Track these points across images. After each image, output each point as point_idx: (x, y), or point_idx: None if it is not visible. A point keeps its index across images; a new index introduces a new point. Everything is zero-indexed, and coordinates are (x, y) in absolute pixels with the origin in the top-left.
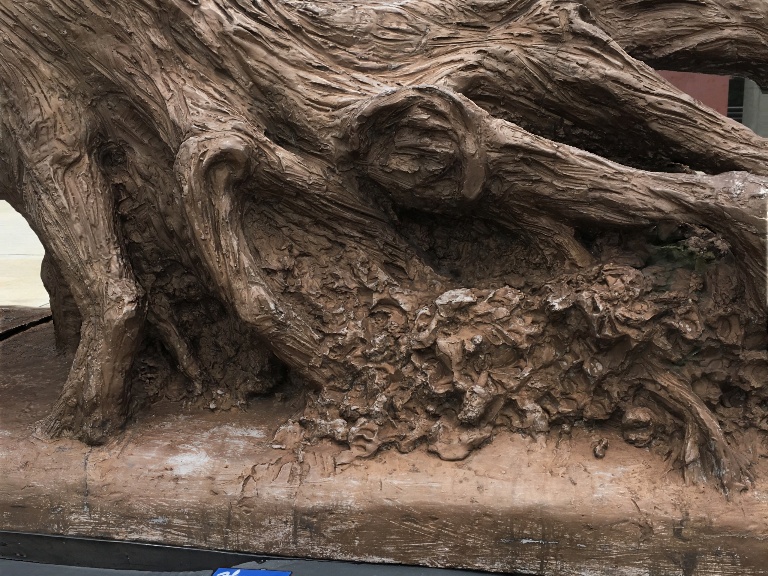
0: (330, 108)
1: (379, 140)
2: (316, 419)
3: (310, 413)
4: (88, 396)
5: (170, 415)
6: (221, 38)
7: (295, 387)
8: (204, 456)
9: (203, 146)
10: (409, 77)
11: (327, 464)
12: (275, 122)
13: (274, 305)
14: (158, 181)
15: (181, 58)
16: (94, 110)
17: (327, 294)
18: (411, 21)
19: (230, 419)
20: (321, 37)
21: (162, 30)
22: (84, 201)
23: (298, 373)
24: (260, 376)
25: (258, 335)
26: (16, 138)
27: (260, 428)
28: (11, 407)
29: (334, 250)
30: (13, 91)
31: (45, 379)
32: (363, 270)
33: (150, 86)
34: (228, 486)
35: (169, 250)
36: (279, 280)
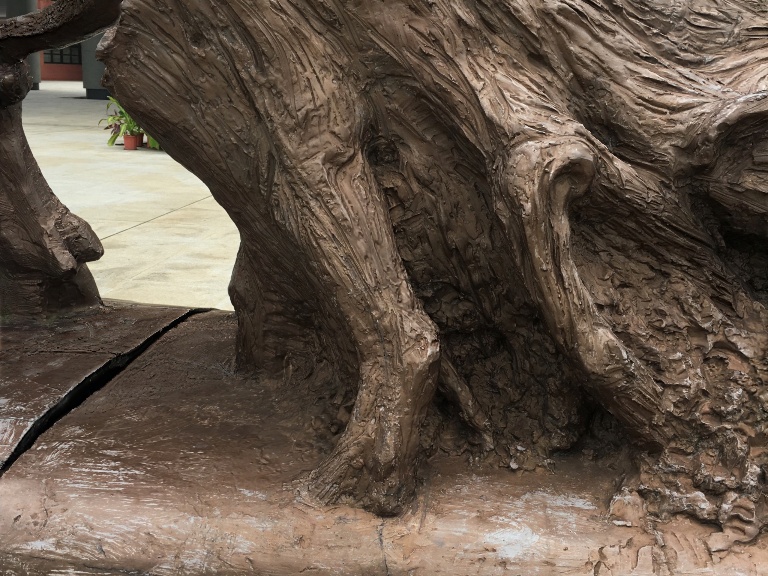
0: (667, 110)
1: (727, 152)
2: (663, 489)
3: (650, 480)
4: (385, 457)
5: (460, 475)
6: (540, 16)
7: (601, 441)
8: (530, 533)
9: (548, 154)
10: (726, 74)
11: (698, 549)
12: (592, 122)
13: (626, 353)
14: (440, 187)
15: (489, 38)
16: (367, 96)
17: (655, 334)
18: (721, 6)
19: (539, 483)
20: (640, 21)
21: (465, 2)
22: (365, 211)
23: (633, 431)
24: (565, 429)
25: (595, 386)
26: (274, 127)
27: (583, 496)
28: (240, 456)
29: (656, 280)
30: (276, 68)
31: (251, 414)
32: (697, 307)
33: (453, 71)
34: (575, 575)
35: (444, 271)
36: (607, 317)
